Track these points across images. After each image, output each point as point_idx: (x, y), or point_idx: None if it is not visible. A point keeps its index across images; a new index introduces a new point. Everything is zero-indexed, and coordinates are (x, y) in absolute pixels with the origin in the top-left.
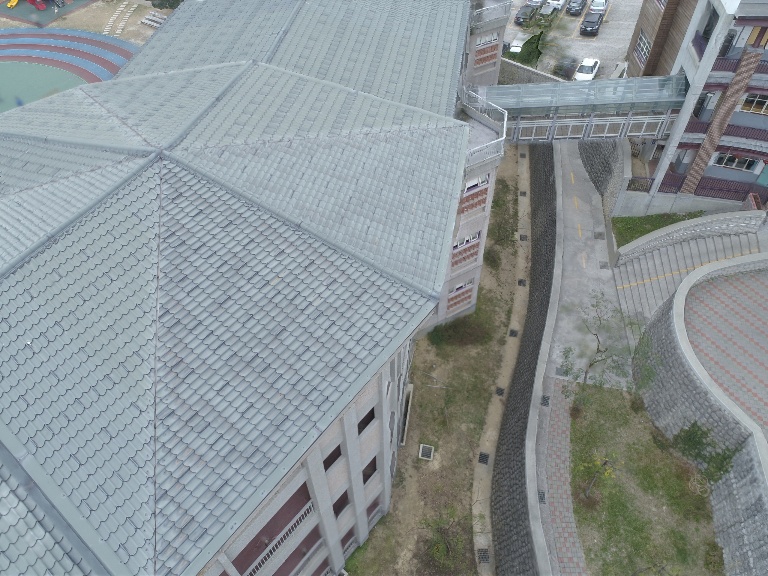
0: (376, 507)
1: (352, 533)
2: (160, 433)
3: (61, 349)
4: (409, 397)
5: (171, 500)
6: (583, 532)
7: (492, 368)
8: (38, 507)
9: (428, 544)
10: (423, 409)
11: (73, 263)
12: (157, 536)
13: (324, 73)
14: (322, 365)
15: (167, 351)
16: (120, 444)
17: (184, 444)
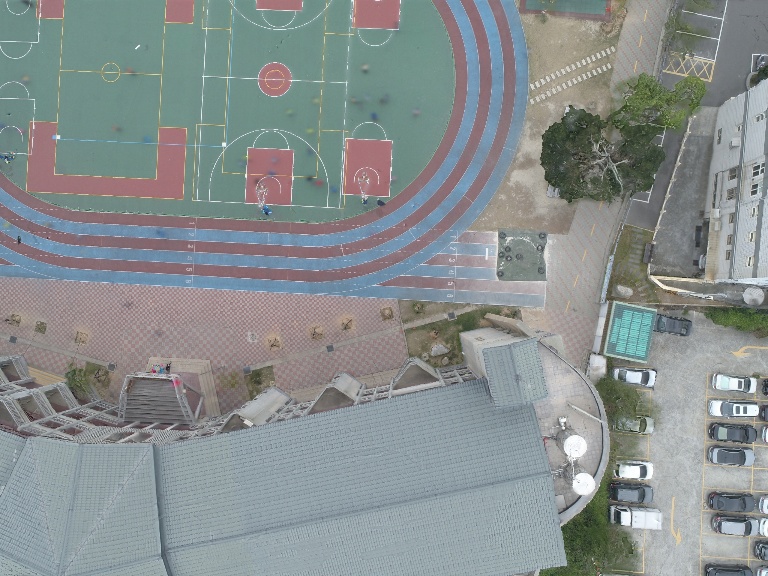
0: None
1: None
2: None
3: None
4: None
5: None
6: None
7: None
8: None
9: None
10: None
11: (15, 573)
12: None
13: (193, 574)
14: None
15: None
16: None
17: None
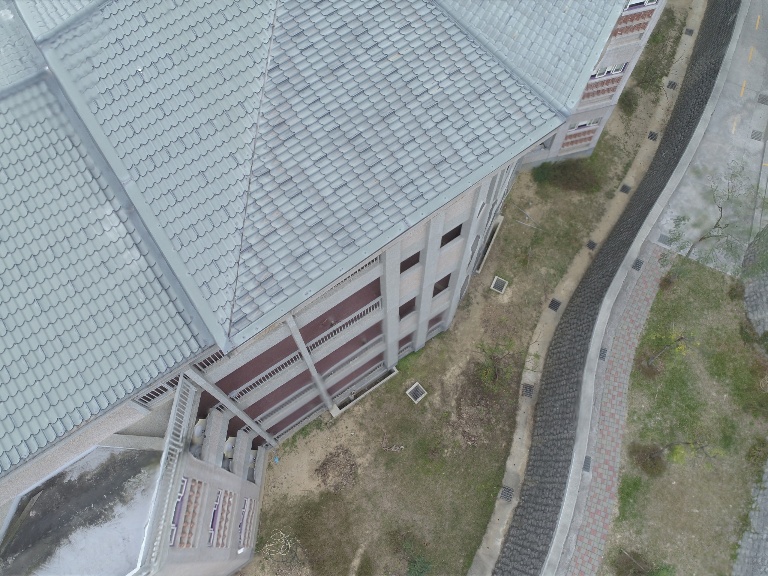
0: (438, 322)
1: (410, 338)
2: (253, 189)
3: (169, 83)
4: (496, 228)
5: (255, 254)
6: (633, 395)
7: (591, 220)
8: (136, 231)
9: (478, 367)
10: (507, 243)
11: None
12: (238, 283)
13: None
14: (424, 160)
15: (271, 109)
16: (215, 191)
17: (274, 205)
